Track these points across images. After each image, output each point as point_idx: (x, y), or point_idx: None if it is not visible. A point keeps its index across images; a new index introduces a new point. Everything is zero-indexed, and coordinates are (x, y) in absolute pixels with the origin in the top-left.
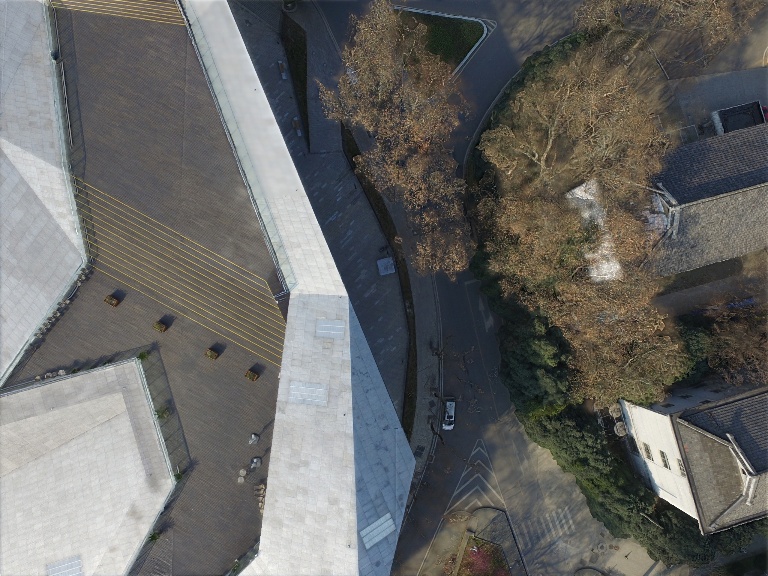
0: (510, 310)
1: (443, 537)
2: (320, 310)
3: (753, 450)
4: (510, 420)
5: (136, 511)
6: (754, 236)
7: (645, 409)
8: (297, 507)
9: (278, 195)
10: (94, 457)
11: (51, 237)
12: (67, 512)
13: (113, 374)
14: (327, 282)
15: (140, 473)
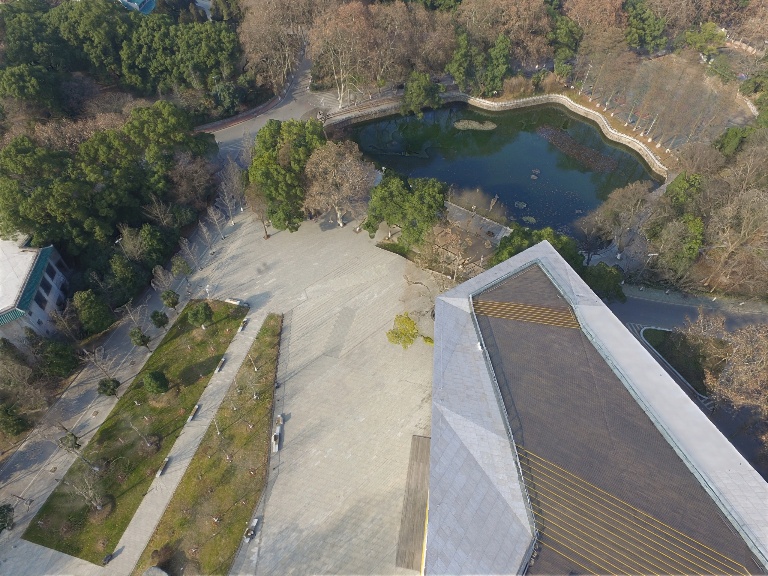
0: None
1: None
2: None
3: None
4: None
5: None
6: None
7: None
8: None
9: (719, 469)
10: None
11: (493, 505)
12: None
13: None
14: None
15: None
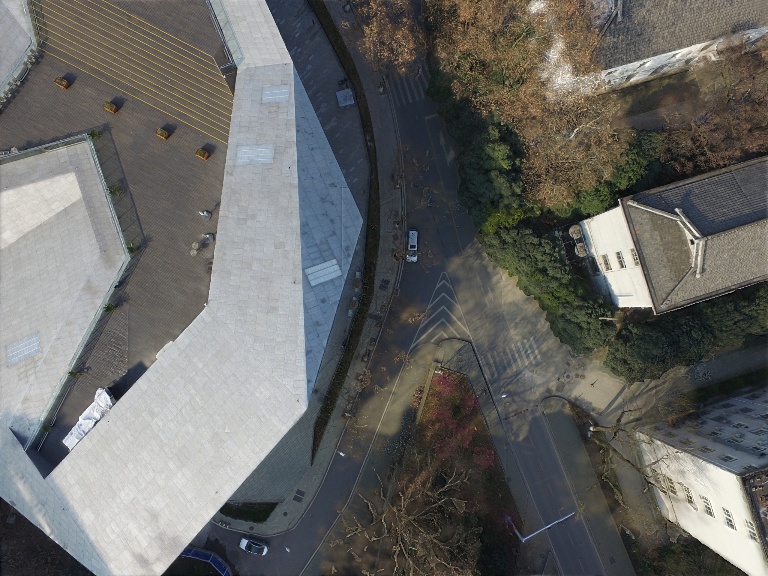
0: (467, 130)
1: (410, 370)
2: (266, 79)
3: (701, 221)
4: (474, 253)
5: (91, 286)
6: (701, 25)
7: (601, 214)
8: (244, 256)
9: None
10: (51, 244)
11: (0, 21)
12: (25, 297)
13: (65, 154)
14: (272, 52)
15: (95, 251)
